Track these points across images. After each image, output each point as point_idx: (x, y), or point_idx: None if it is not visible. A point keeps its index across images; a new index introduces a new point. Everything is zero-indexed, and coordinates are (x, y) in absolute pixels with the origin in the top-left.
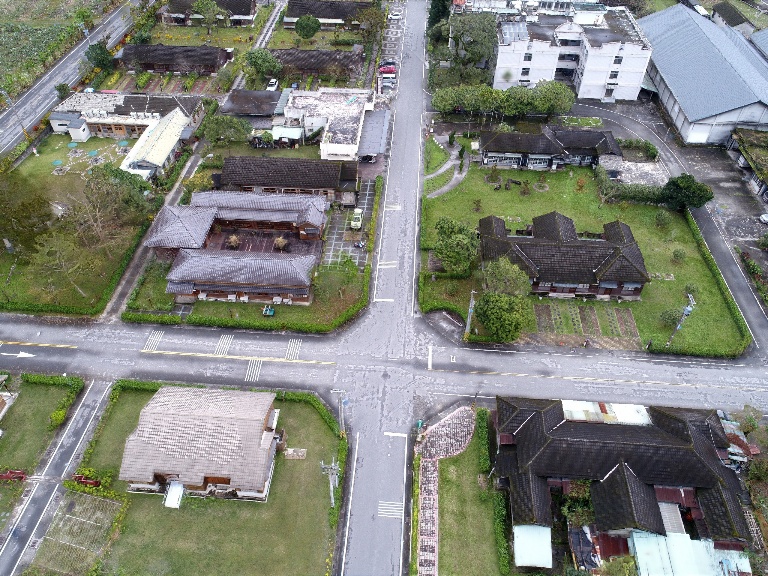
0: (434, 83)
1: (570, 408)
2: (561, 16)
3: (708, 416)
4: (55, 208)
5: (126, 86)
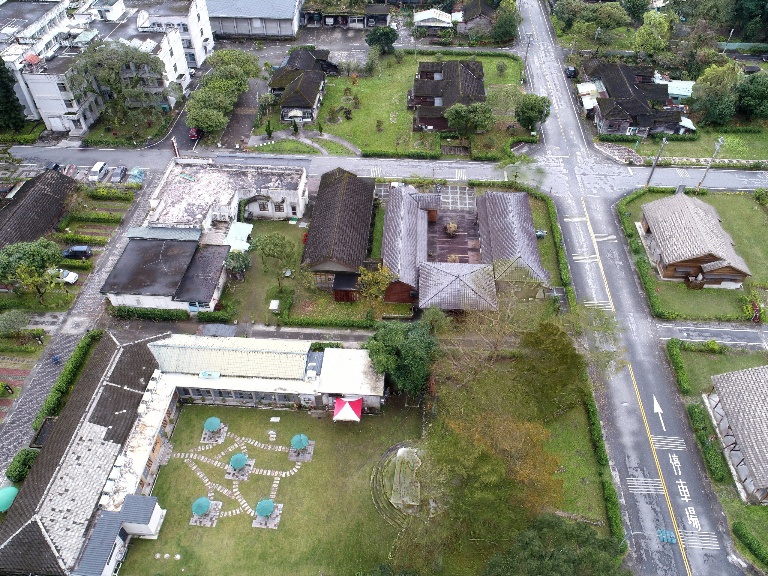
0: (124, 142)
1: (591, 103)
2: (91, 24)
3: (590, 59)
4: None
5: None
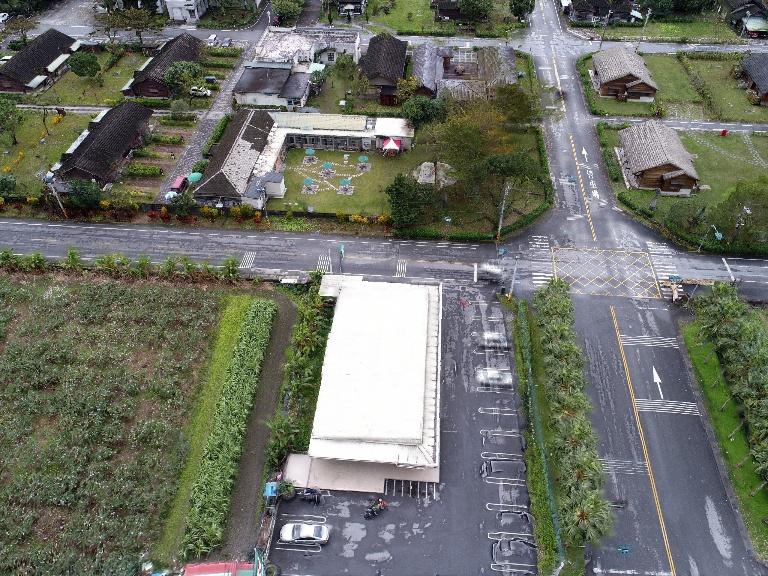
0: None
1: None
2: None
3: None
4: None
5: (147, 186)
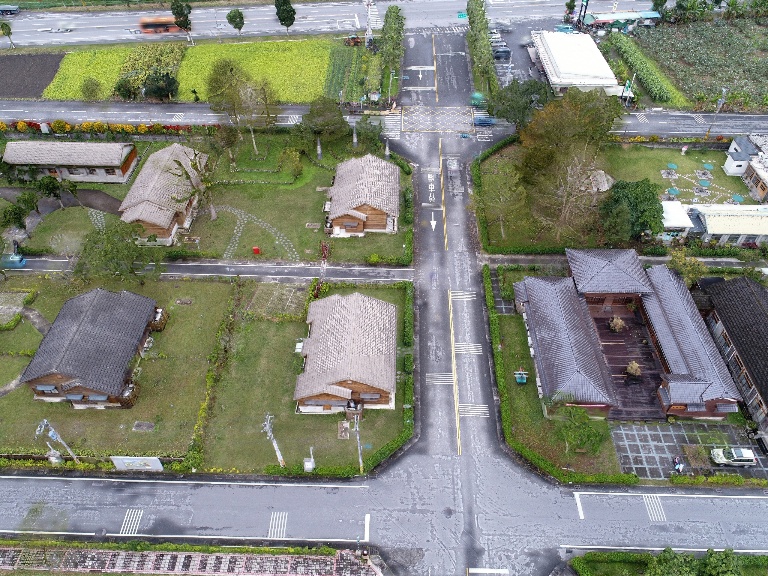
0: None
1: None
2: None
3: None
4: (555, 167)
5: None
